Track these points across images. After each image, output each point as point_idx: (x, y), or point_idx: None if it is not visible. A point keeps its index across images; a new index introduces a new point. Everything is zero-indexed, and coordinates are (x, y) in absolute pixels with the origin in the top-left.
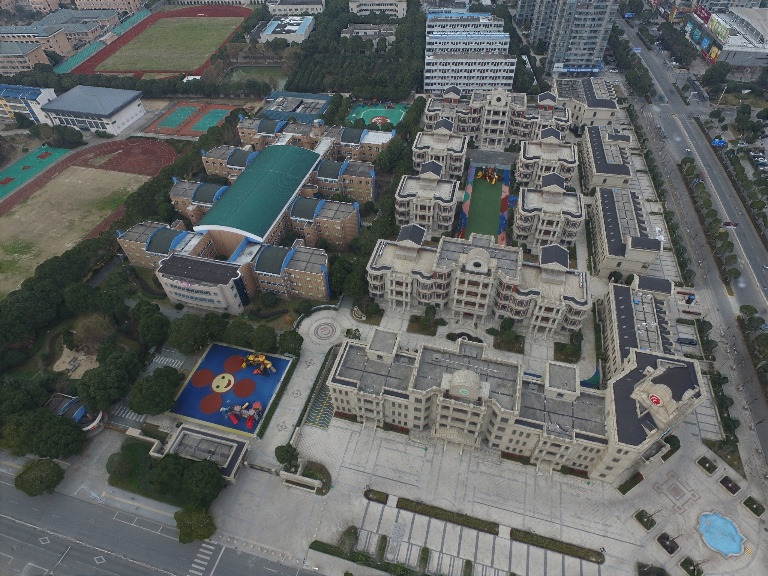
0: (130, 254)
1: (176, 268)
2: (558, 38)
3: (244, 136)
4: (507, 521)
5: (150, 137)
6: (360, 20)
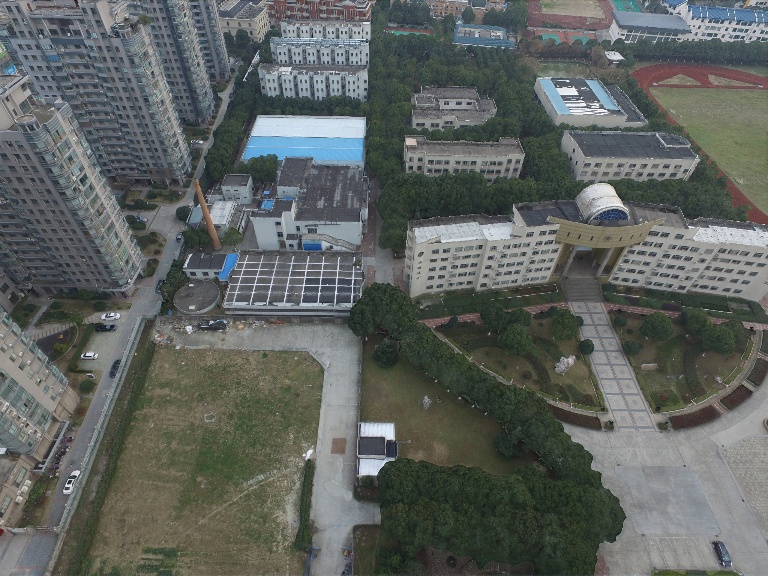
0: None
1: None
2: None
3: None
4: None
5: None
6: None
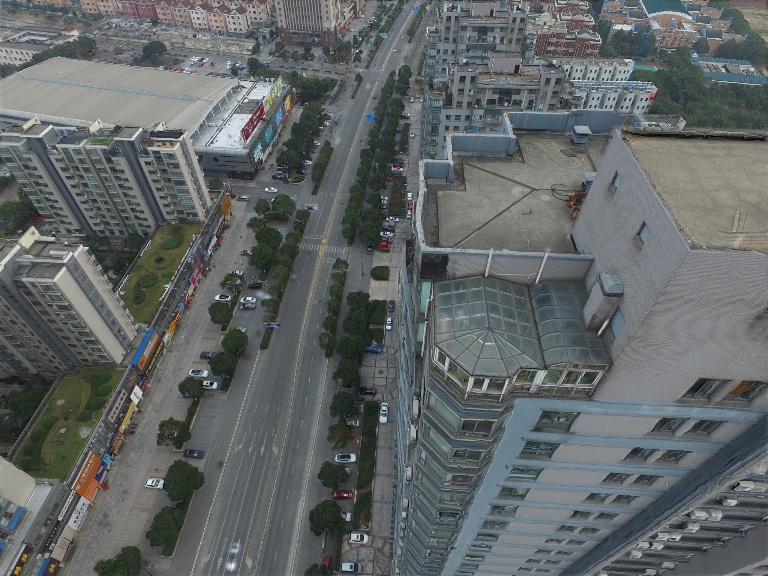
0: None
1: None
2: None
3: None
4: None
5: None
6: None
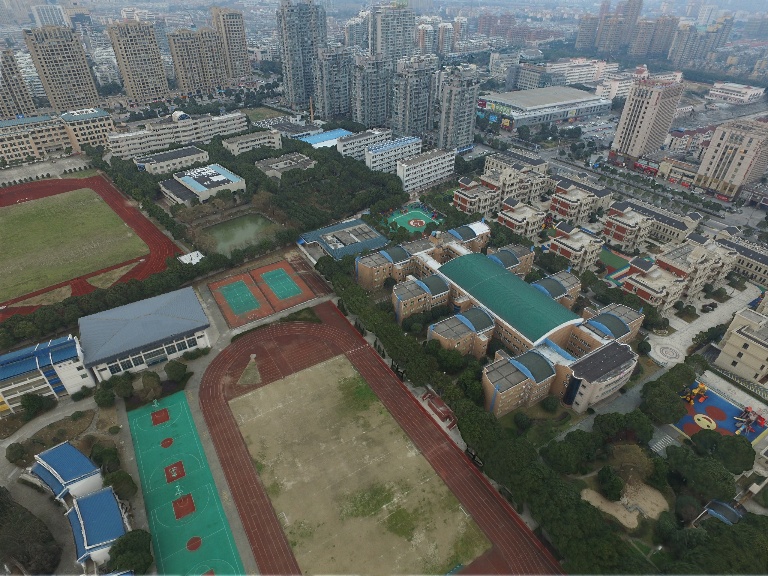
0: (501, 406)
1: (590, 373)
2: (448, 132)
3: (378, 274)
4: None
5: (259, 326)
6: (258, 157)
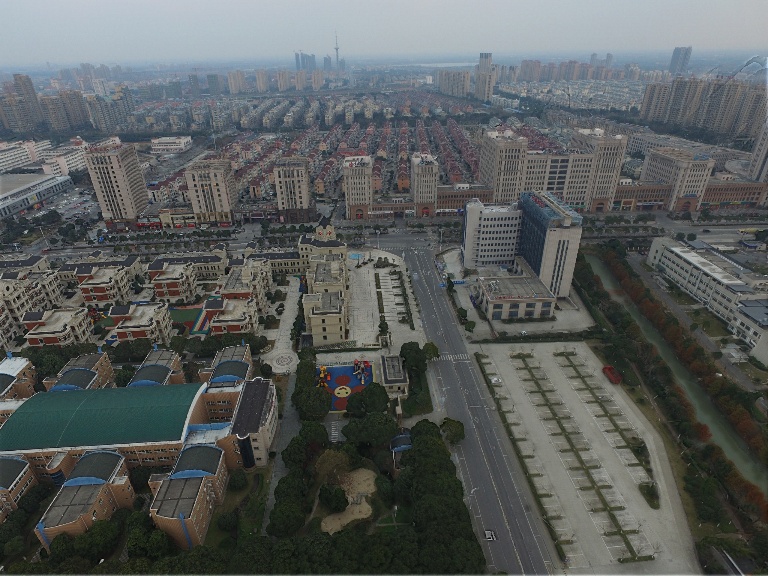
0: (198, 529)
1: (250, 424)
2: None
3: None
4: (374, 290)
5: None
6: None
